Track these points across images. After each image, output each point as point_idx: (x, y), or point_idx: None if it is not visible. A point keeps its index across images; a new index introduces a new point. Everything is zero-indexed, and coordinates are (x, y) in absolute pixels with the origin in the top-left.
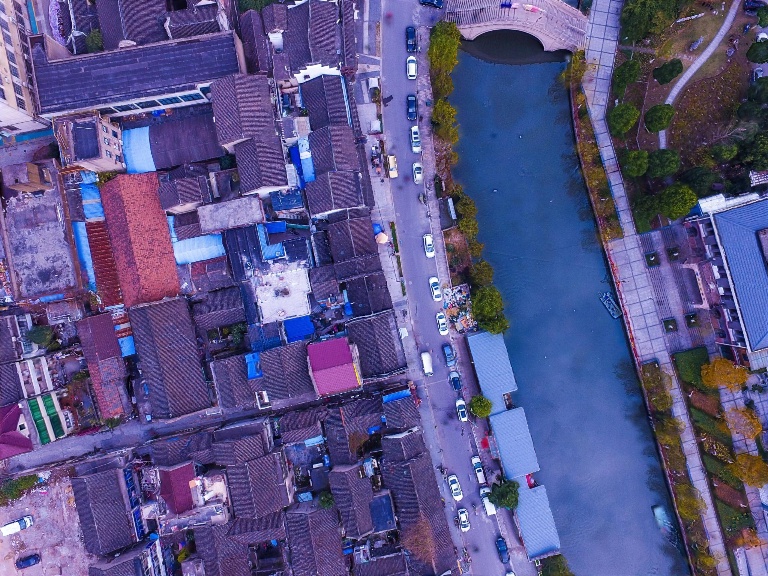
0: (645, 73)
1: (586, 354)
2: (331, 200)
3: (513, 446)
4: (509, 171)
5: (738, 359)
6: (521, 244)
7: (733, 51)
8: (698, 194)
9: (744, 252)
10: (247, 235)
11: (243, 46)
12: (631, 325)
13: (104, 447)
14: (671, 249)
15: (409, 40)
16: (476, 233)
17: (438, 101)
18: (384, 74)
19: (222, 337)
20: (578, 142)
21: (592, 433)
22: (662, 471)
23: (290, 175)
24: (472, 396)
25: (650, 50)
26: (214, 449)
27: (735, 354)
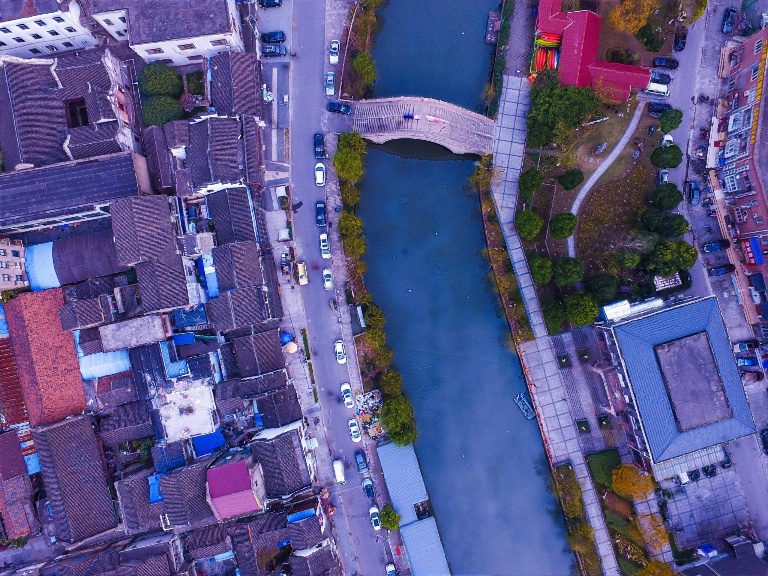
0: (553, 176)
1: (502, 454)
2: (232, 319)
3: (424, 557)
4: (425, 269)
5: (645, 466)
6: (439, 340)
7: (638, 154)
8: (604, 299)
9: (643, 366)
10: (150, 353)
11: (146, 160)
12: (545, 426)
13: (14, 562)
14: (582, 351)
15: (317, 147)
16: (382, 345)
17: (342, 214)
18: (293, 180)
19: (131, 451)
20: (489, 244)
21: (511, 531)
22: (579, 571)
23: (191, 294)
24: (385, 504)
25: (557, 153)
26: (119, 571)
27: (643, 461)
